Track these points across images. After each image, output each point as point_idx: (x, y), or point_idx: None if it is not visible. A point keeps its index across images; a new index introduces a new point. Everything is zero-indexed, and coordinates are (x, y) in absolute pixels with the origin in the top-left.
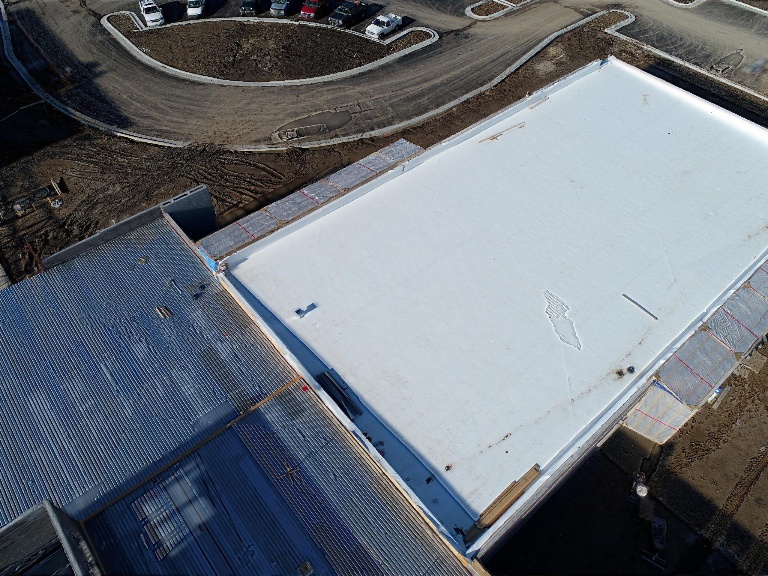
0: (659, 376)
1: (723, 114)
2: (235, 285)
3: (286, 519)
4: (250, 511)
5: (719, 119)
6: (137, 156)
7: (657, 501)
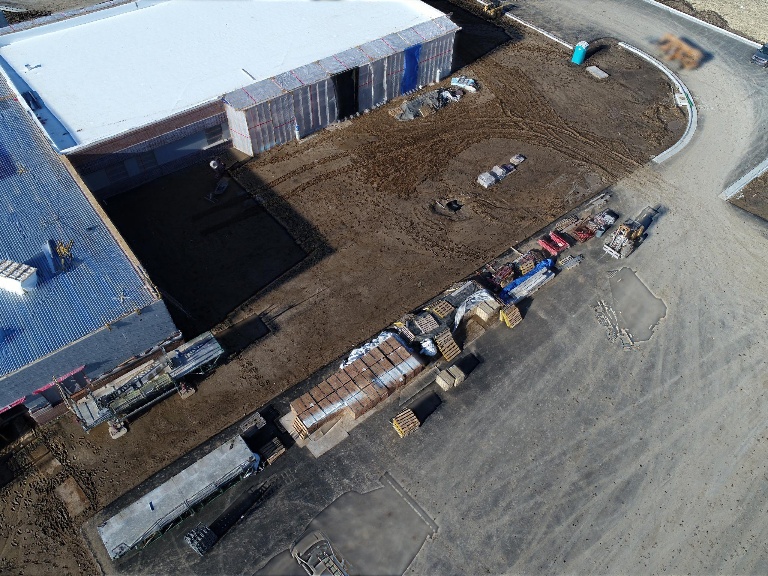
0: (225, 95)
1: None
2: None
3: None
4: None
5: None
6: None
7: (232, 179)
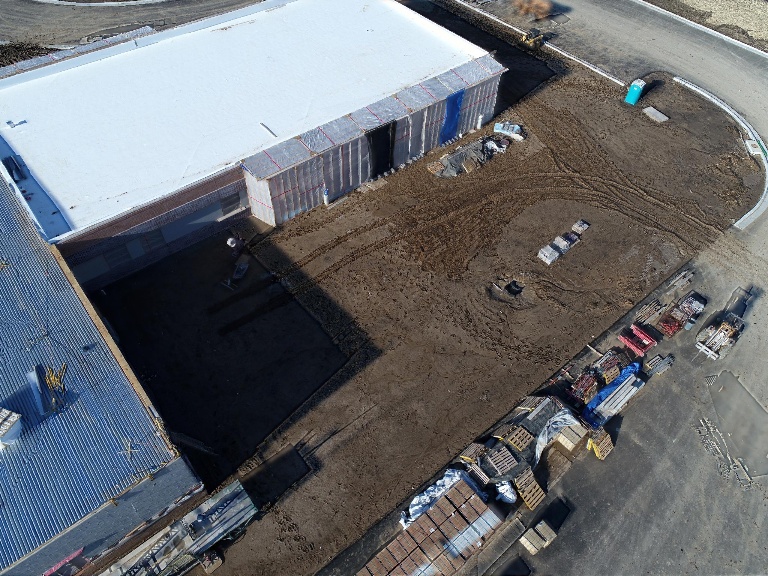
0: (244, 161)
1: (418, 18)
2: None
3: None
4: None
5: (415, 22)
6: None
7: (253, 257)
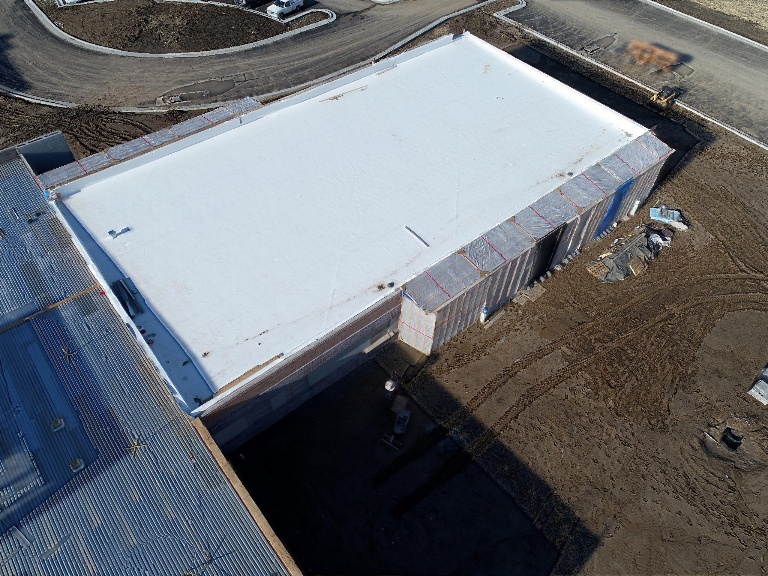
0: (405, 287)
1: (551, 82)
2: (63, 211)
3: (54, 389)
4: (25, 382)
5: (547, 87)
6: (28, 114)
7: (410, 399)
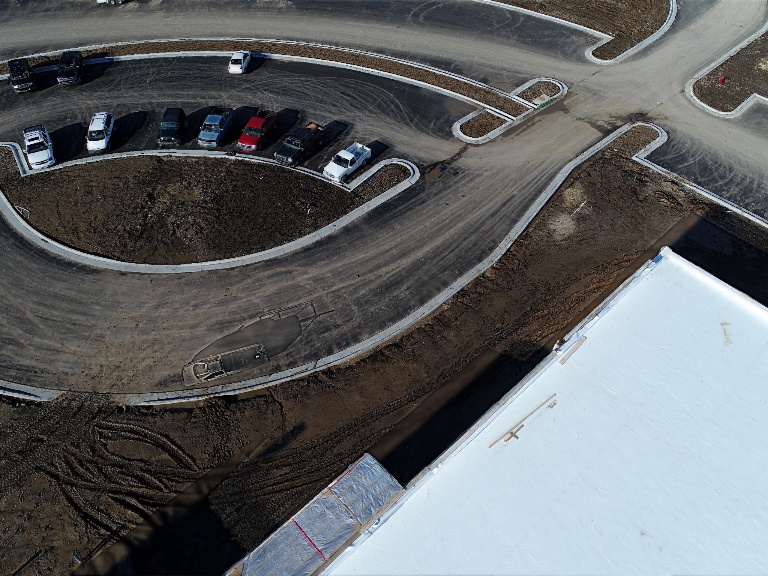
0: None
1: None
2: None
3: None
4: None
5: None
6: None
7: None
